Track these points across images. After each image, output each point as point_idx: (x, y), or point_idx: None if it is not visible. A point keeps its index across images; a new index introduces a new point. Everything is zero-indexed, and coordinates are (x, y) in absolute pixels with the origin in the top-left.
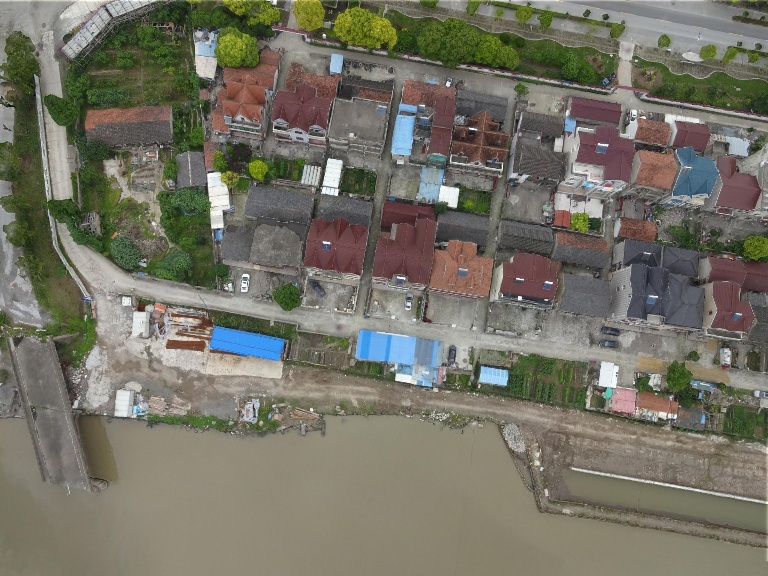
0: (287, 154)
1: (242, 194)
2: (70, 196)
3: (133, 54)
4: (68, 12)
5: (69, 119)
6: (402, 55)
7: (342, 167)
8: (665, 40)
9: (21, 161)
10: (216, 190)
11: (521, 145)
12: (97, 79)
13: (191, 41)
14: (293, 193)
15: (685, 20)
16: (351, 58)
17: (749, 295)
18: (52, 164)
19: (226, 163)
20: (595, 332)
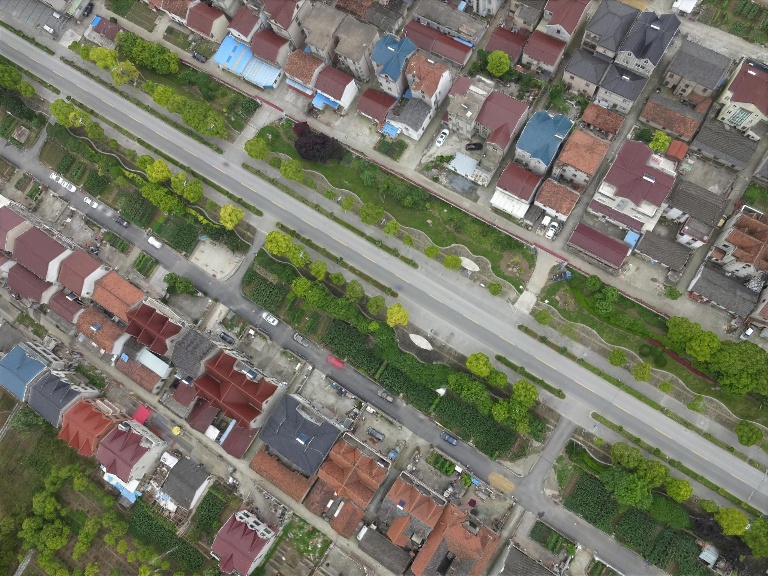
0: None
1: None
2: None
3: None
4: None
5: None
6: None
7: None
8: (497, 287)
9: None
10: None
11: (710, 226)
12: None
13: None
14: None
15: (448, 312)
16: None
17: (534, 20)
18: None
19: None
20: (678, 44)
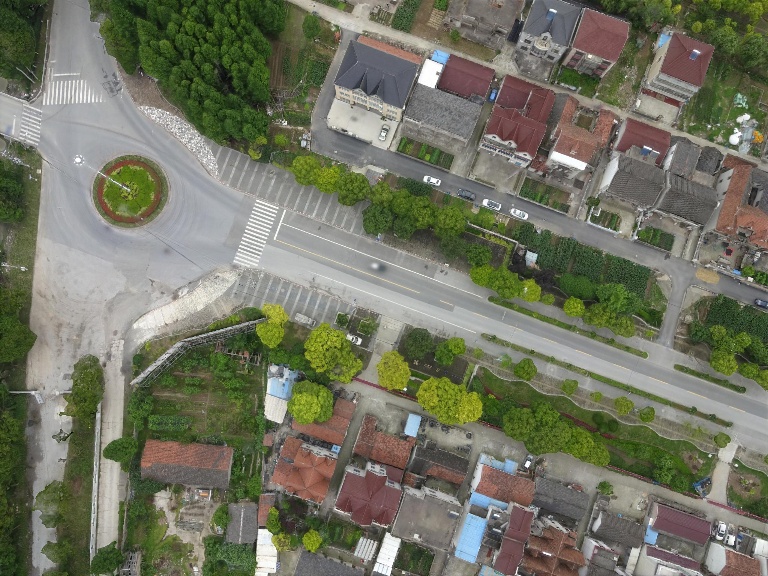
0: (344, 514)
1: (291, 551)
2: (115, 527)
3: (202, 378)
4: (142, 321)
5: (126, 459)
6: (484, 423)
7: (400, 545)
8: None
9: (71, 484)
10: (265, 549)
11: (595, 565)
12: (161, 398)
13: (264, 369)
14: (344, 567)
15: None
16: (429, 415)
17: None
18: (102, 489)
19: (280, 524)
20: None
